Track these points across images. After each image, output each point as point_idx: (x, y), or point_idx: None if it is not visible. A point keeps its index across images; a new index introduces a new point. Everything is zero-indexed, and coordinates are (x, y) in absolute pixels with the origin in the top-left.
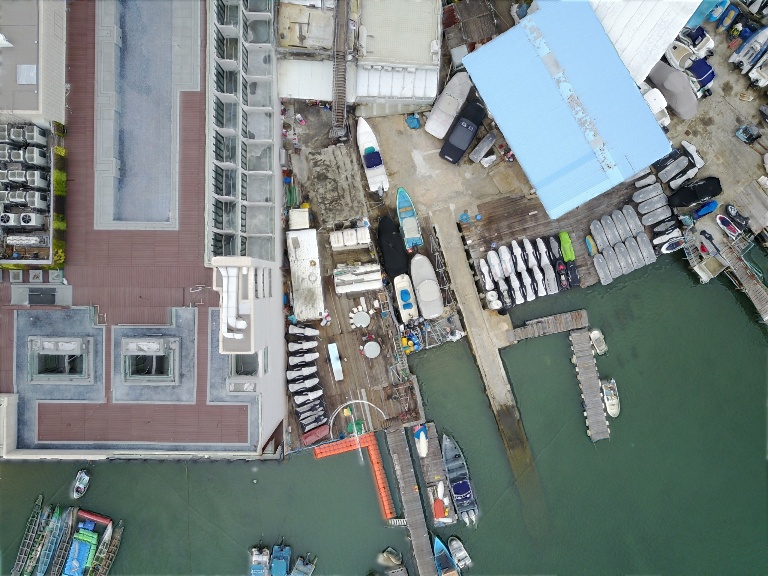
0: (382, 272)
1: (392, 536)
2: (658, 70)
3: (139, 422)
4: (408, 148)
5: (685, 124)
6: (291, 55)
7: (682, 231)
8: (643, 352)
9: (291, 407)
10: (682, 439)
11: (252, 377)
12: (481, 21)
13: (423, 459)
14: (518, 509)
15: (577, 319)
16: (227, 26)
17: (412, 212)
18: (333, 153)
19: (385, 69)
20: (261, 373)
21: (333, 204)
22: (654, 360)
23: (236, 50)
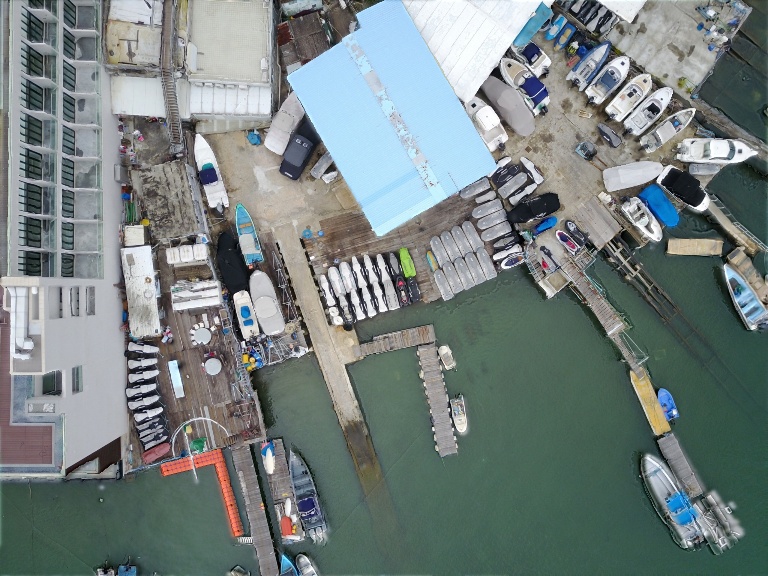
0: (223, 288)
1: (241, 554)
2: (493, 87)
3: None
4: (250, 164)
5: (525, 140)
6: (122, 72)
7: (523, 246)
8: (492, 367)
9: (132, 425)
10: (533, 453)
11: (56, 397)
12: (314, 39)
13: (270, 476)
14: (369, 525)
15: (424, 334)
16: (39, 44)
17: (252, 228)
18: (163, 170)
19: (217, 86)
20: (64, 393)
21: (163, 221)
22: (503, 375)
23: (54, 67)
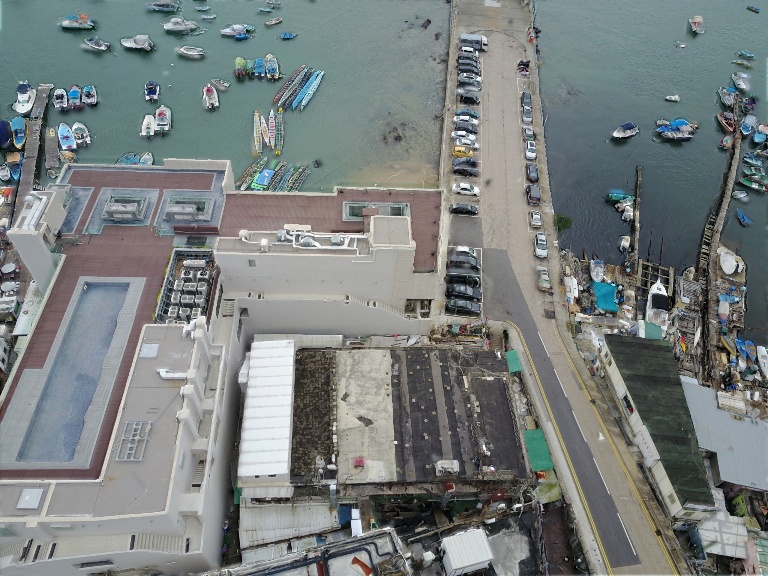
0: None
1: None
2: None
3: (144, 180)
4: None
5: None
6: None
7: None
8: None
9: None
10: None
11: None
12: None
13: (6, 217)
14: None
15: None
16: None
17: None
18: None
19: None
20: None
21: None
22: None
23: None
